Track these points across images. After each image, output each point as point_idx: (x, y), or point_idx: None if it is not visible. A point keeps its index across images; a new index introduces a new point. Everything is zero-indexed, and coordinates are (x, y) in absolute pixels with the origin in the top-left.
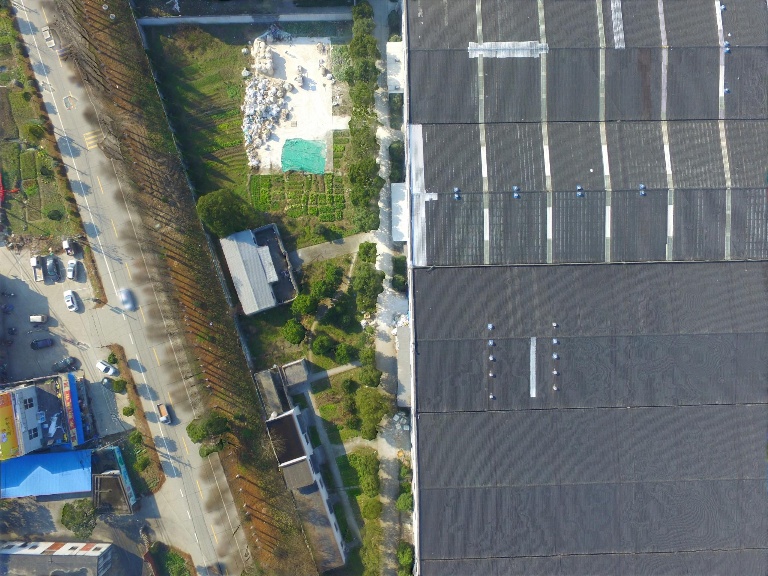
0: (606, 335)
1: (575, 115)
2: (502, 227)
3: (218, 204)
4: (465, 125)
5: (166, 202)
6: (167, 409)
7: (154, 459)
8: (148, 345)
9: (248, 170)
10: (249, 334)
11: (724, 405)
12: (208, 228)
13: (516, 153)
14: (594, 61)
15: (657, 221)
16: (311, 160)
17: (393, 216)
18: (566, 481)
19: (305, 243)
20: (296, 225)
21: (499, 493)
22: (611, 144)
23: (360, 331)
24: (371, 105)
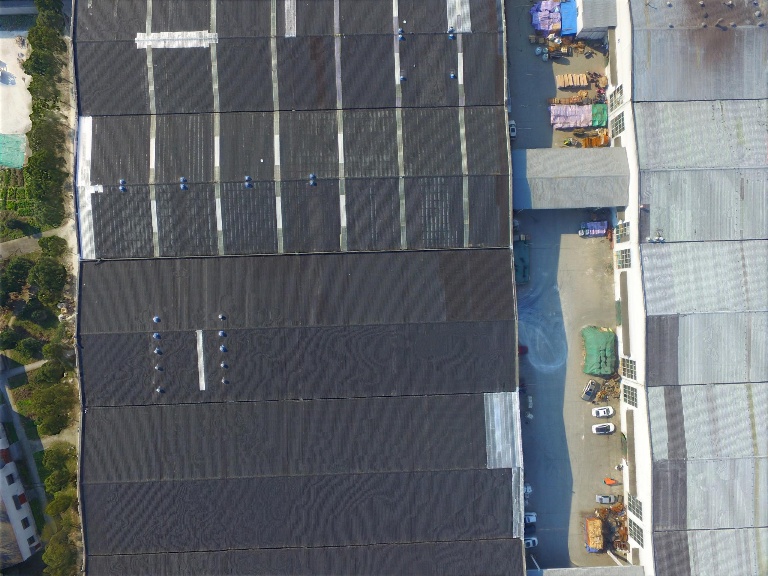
0: (274, 327)
1: (248, 105)
2: (170, 219)
3: None
4: (136, 116)
5: None
6: None
7: None
8: None
9: None
10: None
11: (399, 397)
12: None
13: (186, 144)
14: (265, 50)
15: (329, 211)
16: (10, 154)
17: None
18: (232, 475)
19: (3, 238)
20: None
21: (163, 487)
22: (284, 134)
23: None
24: (53, 98)
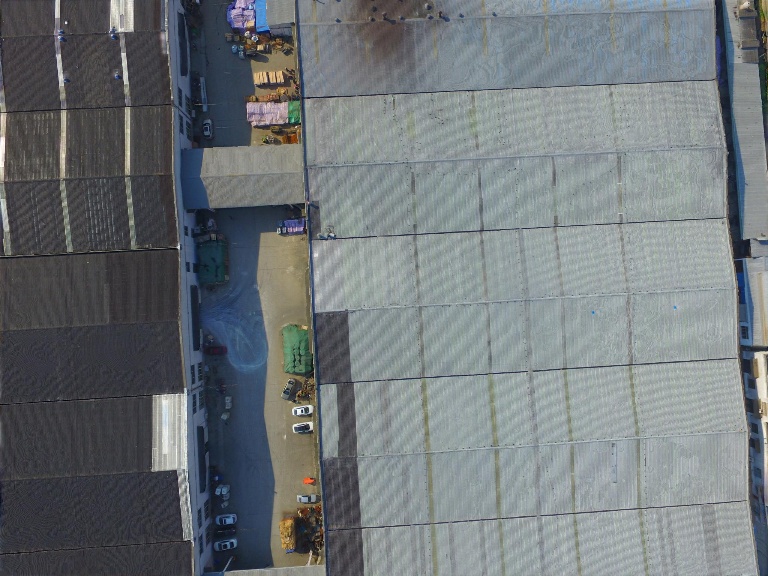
0: None
1: None
2: None
3: None
4: None
5: None
6: None
7: None
8: None
9: None
10: None
11: (65, 401)
12: None
13: None
14: None
15: None
16: None
17: None
18: None
19: None
20: None
21: None
22: None
23: None
24: None
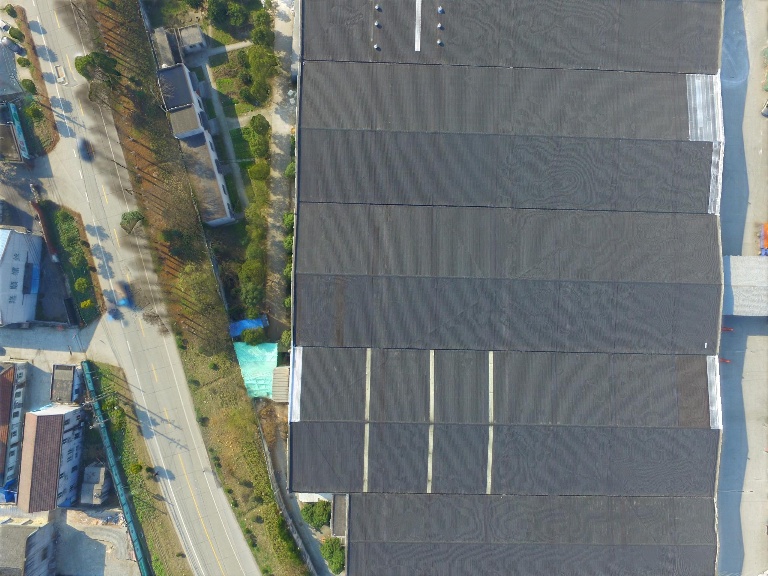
0: None
1: None
2: None
3: None
4: None
5: None
6: (65, 71)
7: (49, 118)
8: (49, 8)
9: None
10: (150, 6)
11: (605, 71)
12: None
13: None
14: None
15: None
16: None
17: None
18: (445, 130)
19: None
20: None
21: (378, 137)
22: None
23: (260, 9)
24: None
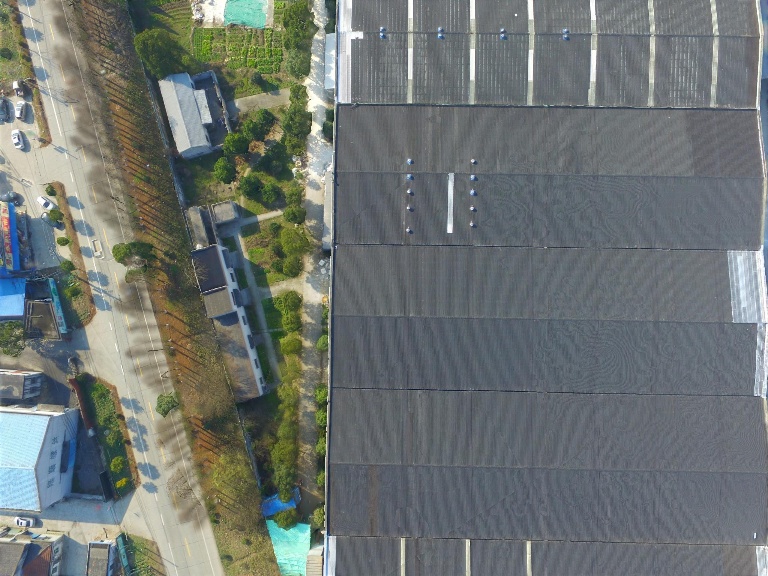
0: (524, 173)
1: None
2: (426, 67)
3: (154, 38)
4: None
5: (112, 49)
6: (102, 245)
7: (86, 292)
8: (87, 183)
9: (192, 23)
10: (184, 178)
11: (643, 249)
12: (149, 71)
13: None
14: None
15: (580, 66)
16: (252, 15)
17: (326, 65)
18: (479, 315)
19: (243, 93)
20: (235, 76)
21: (411, 323)
22: None
23: (291, 179)
24: None
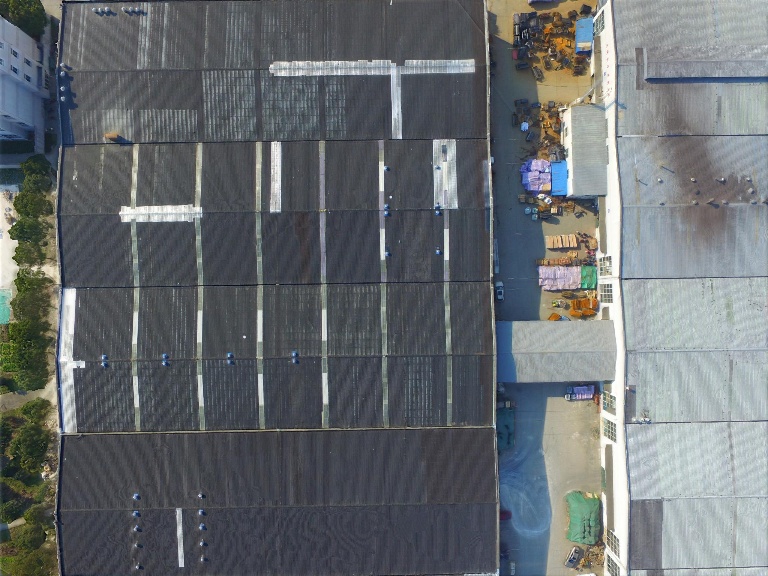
0: (254, 506)
1: (232, 279)
2: (152, 394)
3: None
4: (120, 289)
5: None
6: None
7: None
8: None
9: None
10: None
11: None
12: None
13: (169, 319)
14: (250, 225)
15: (311, 389)
16: None
17: None
18: None
19: None
20: None
21: None
22: (267, 309)
23: (41, 483)
24: (38, 262)
